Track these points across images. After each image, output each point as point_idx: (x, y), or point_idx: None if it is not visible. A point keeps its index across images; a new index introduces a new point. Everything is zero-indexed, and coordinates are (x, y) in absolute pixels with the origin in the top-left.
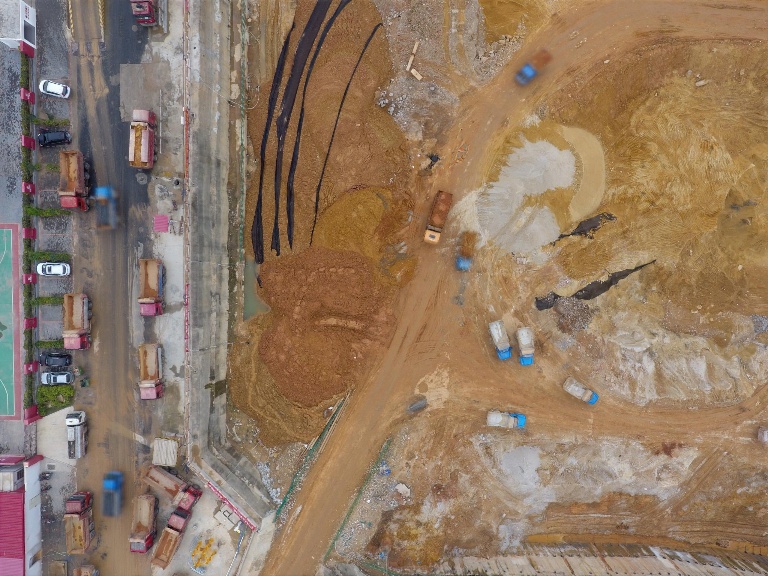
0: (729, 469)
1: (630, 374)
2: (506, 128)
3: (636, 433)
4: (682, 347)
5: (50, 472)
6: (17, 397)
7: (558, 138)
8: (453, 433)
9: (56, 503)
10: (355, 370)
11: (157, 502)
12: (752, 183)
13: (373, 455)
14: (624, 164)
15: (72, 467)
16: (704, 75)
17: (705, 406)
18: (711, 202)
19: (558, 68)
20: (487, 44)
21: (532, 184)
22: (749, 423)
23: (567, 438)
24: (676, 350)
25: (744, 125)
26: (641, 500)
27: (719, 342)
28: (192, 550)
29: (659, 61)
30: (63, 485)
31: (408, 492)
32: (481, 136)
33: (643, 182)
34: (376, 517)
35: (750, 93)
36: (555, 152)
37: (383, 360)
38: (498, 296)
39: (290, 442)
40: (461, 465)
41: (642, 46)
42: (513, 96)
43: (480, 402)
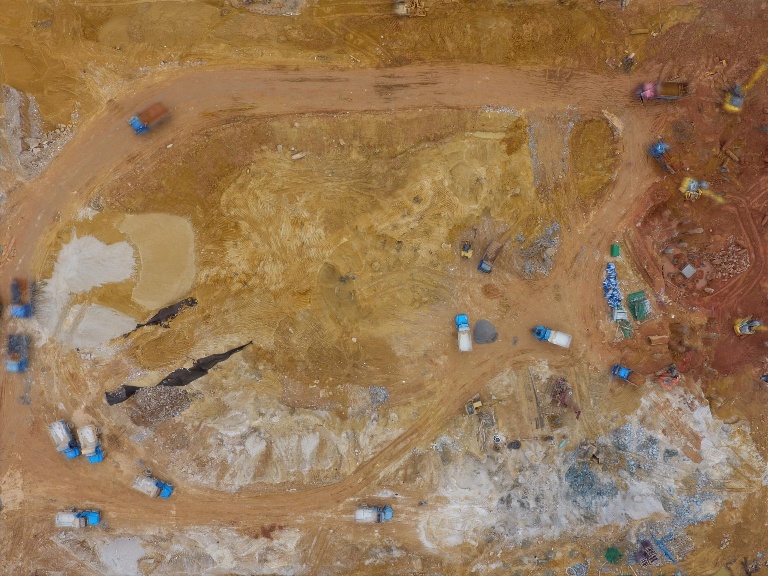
0: (339, 546)
1: (225, 459)
2: (58, 222)
3: (229, 519)
4: (294, 424)
5: None
6: None
7: (109, 231)
8: (32, 533)
9: None
10: None
11: None
12: (355, 256)
13: None
14: (214, 245)
15: None
16: (299, 148)
17: (304, 487)
18: (302, 280)
19: (116, 156)
20: (43, 134)
21: (73, 283)
22: (352, 500)
23: (151, 531)
24: (288, 428)
25: (352, 195)
26: None
27: (340, 415)
28: None
29: (236, 140)
30: None
31: None
32: (32, 232)
33: (235, 262)
34: None
35: (355, 162)
36: (96, 248)
37: None
38: (67, 393)
39: None
40: (45, 564)
41: (210, 127)
42: (63, 189)
43: (57, 501)
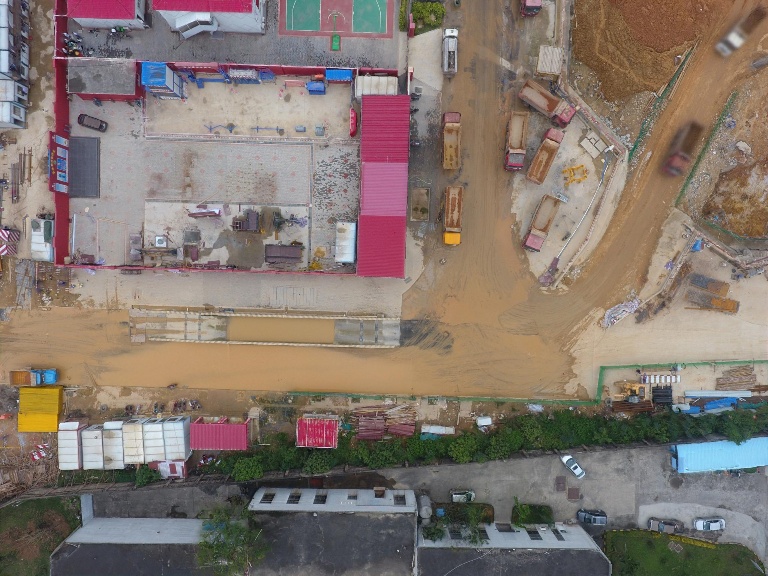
0: None
1: None
2: None
3: None
4: None
5: None
6: (390, 14)
7: None
8: None
9: (421, 128)
10: (701, 22)
11: None
12: None
13: (719, 107)
14: None
15: (438, 92)
16: None
17: None
18: None
19: None
20: None
21: None
22: None
23: None
24: None
25: None
26: None
27: None
28: (556, 179)
29: None
30: (429, 110)
31: (749, 149)
32: None
33: None
34: (716, 175)
35: None
36: None
37: (728, 13)
38: None
39: (635, 93)
40: None
41: None
42: None
43: None
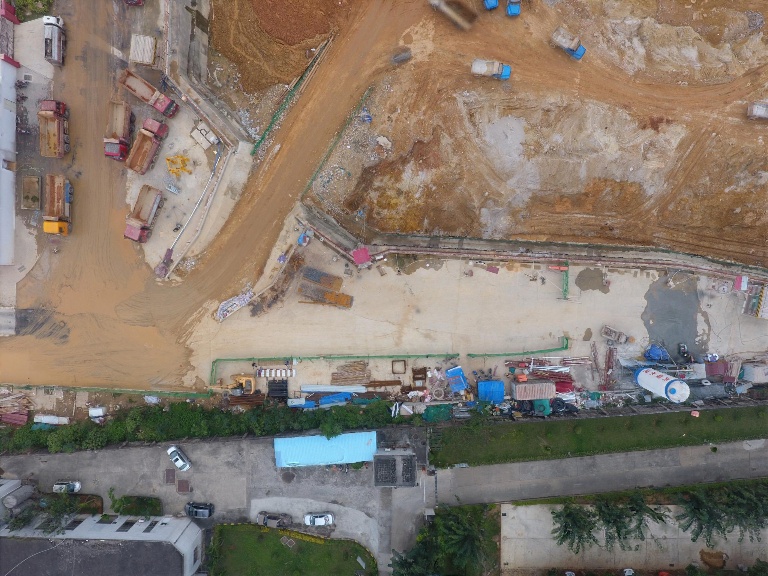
0: (717, 154)
1: (619, 47)
2: None
3: (623, 102)
4: (674, 35)
5: (26, 81)
6: None
7: None
8: (437, 88)
9: (32, 116)
10: (339, 15)
11: (134, 118)
12: None
13: (355, 101)
14: None
15: (49, 80)
16: None
17: (695, 82)
18: None
19: None
20: None
21: None
22: (739, 103)
23: (553, 98)
24: (668, 38)
25: None
26: (626, 190)
27: (712, 39)
28: (167, 169)
29: None
30: (39, 98)
31: (389, 144)
32: None
33: None
34: (356, 169)
35: None
36: None
37: (368, 7)
38: None
39: (271, 85)
40: (444, 123)
41: None
42: None
43: (465, 56)
